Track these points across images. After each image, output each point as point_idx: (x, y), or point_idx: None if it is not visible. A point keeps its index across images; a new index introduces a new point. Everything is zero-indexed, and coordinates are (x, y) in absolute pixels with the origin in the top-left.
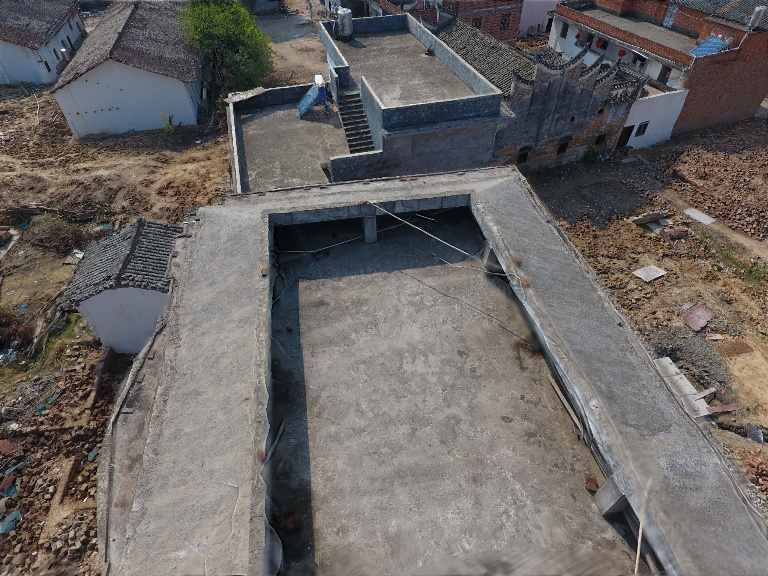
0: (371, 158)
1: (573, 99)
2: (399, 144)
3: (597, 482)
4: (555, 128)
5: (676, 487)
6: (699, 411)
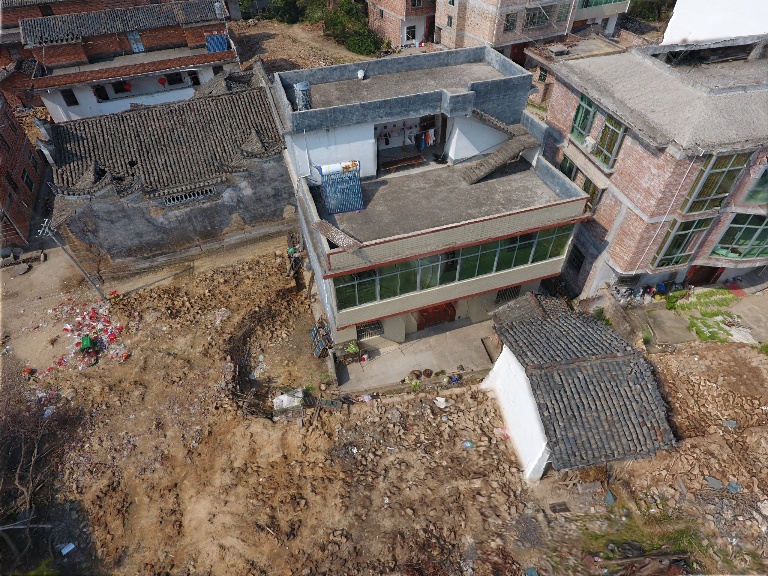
0: None
1: None
2: None
3: (766, 45)
4: None
5: None
6: None
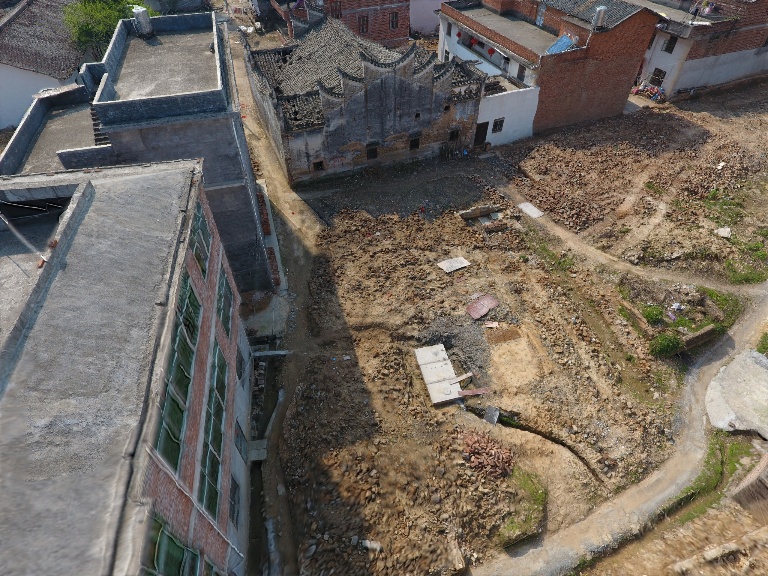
0: (101, 152)
1: (412, 96)
2: (127, 138)
3: None
4: (400, 124)
5: (35, 443)
6: (450, 395)
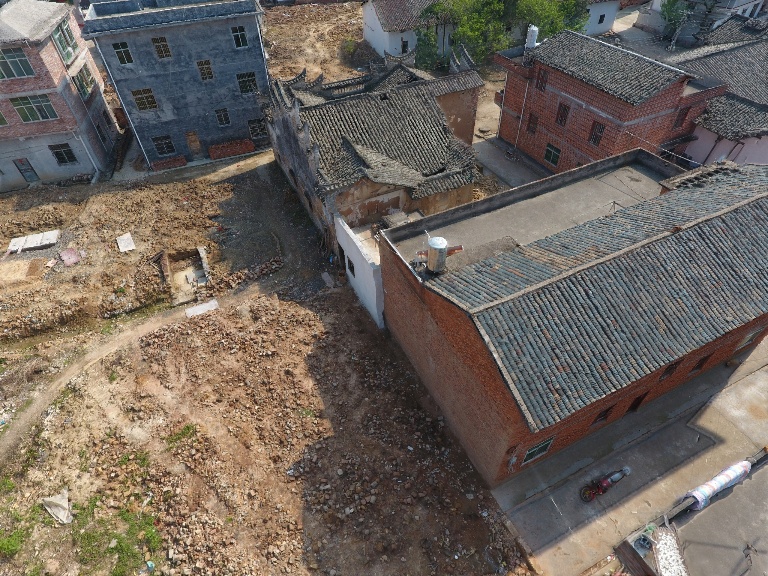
0: None
1: None
2: None
3: None
4: None
5: None
6: (12, 245)
